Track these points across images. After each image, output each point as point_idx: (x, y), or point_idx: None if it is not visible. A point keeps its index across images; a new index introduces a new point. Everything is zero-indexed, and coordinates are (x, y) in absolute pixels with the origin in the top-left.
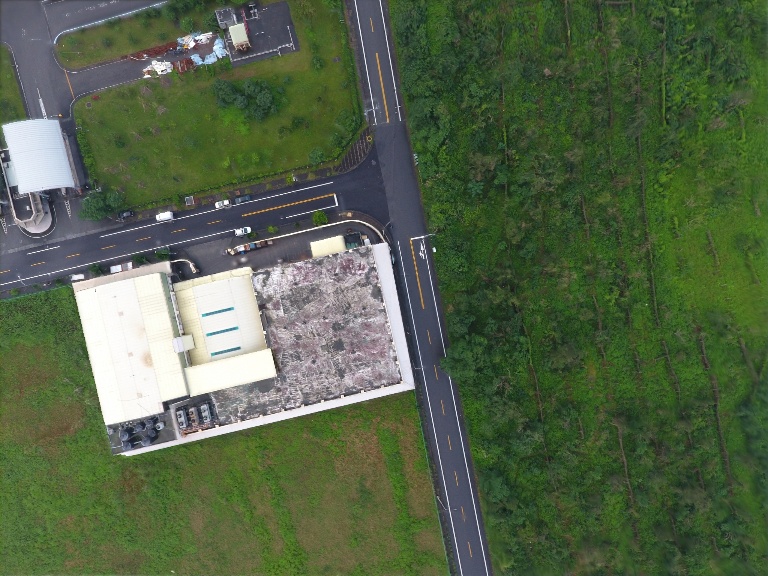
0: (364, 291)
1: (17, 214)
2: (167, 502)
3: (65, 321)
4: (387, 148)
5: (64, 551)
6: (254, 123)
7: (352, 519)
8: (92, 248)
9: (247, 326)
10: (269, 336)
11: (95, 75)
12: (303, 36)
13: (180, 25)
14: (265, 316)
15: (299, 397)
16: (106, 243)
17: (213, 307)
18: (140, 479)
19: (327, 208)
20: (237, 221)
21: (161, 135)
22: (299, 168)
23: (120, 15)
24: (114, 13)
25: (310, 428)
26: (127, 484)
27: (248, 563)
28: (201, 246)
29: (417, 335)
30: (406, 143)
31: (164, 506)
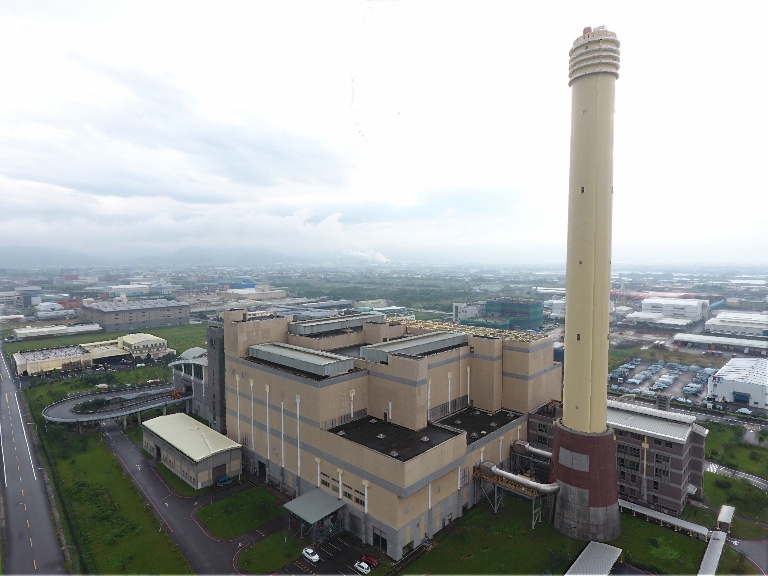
0: None
1: None
2: None
3: None
4: None
5: None
6: None
7: None
8: None
9: None
10: None
11: None
12: None
13: None
14: None
15: None
16: None
17: None
18: None
19: None
20: None
21: None
22: None
23: None
24: None
25: None
26: None
27: None
28: None
29: (7, 370)
30: None
31: None
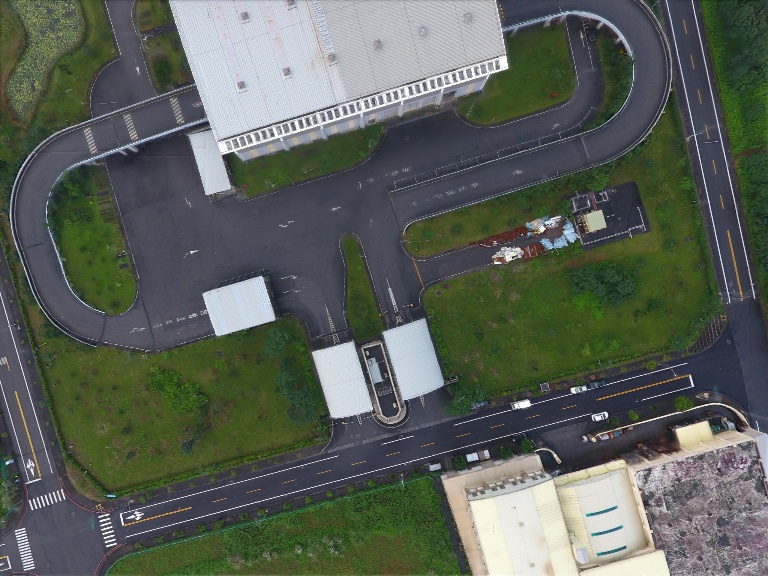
0: (747, 485)
1: (382, 411)
2: None
3: (424, 511)
4: (742, 327)
5: None
6: (608, 307)
7: None
8: (447, 436)
9: (629, 523)
10: (654, 534)
11: (443, 263)
12: (653, 216)
13: (534, 213)
14: (650, 514)
15: None
16: (460, 431)
17: (598, 507)
18: None
19: (683, 389)
20: (592, 405)
21: (514, 322)
22: (656, 351)
23: (471, 204)
24: (462, 201)
25: None
26: None
27: None
28: (556, 431)
29: None
30: (760, 320)
31: None
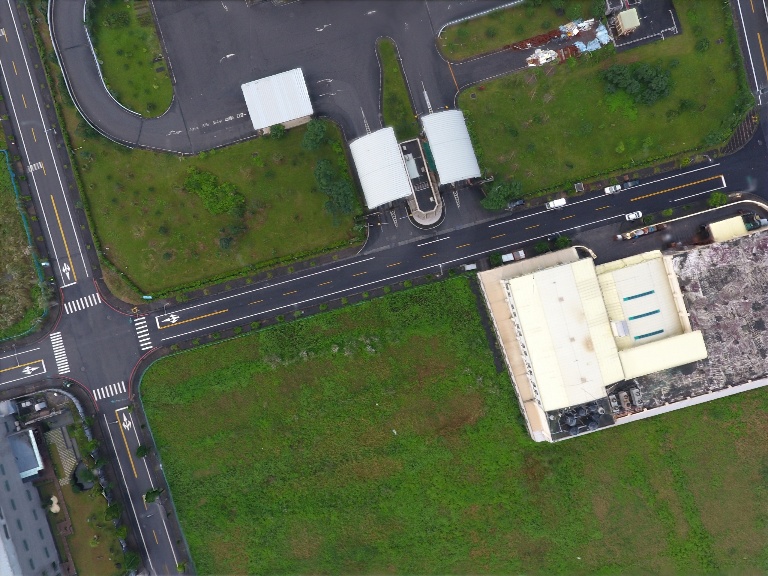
0: None
1: (419, 206)
2: (571, 489)
3: (460, 311)
4: None
5: (469, 541)
6: (641, 107)
7: (757, 500)
8: (482, 238)
9: (666, 309)
10: (691, 318)
11: (478, 66)
12: (685, 19)
13: (568, 13)
14: (686, 298)
15: (722, 378)
16: (495, 232)
17: (635, 291)
18: (543, 466)
19: (715, 190)
20: (626, 206)
21: (549, 123)
22: (688, 151)
23: (505, 5)
24: (497, 4)
25: (710, 410)
26: (530, 472)
27: (653, 548)
28: (590, 232)
29: None
30: None
31: (568, 493)
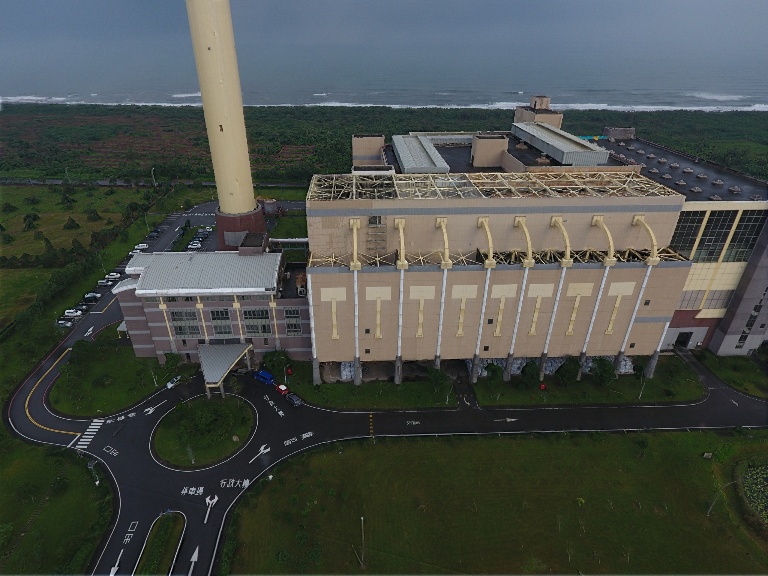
0: None
1: None
2: None
3: None
4: None
5: None
6: None
7: None
8: None
9: None
10: None
11: None
12: None
13: None
14: None
15: None
16: None
17: None
18: None
19: None
20: None
21: None
22: None
23: None
24: None
25: None
26: None
27: None
28: None
29: None
30: None
31: None
